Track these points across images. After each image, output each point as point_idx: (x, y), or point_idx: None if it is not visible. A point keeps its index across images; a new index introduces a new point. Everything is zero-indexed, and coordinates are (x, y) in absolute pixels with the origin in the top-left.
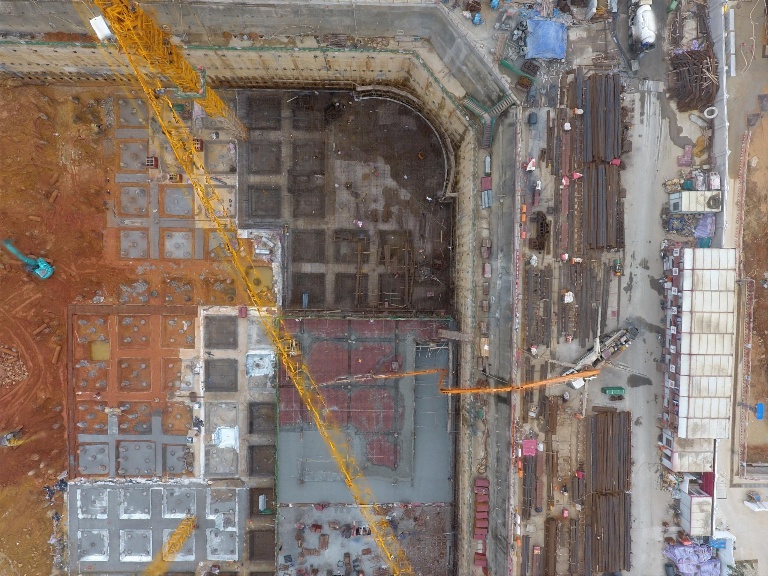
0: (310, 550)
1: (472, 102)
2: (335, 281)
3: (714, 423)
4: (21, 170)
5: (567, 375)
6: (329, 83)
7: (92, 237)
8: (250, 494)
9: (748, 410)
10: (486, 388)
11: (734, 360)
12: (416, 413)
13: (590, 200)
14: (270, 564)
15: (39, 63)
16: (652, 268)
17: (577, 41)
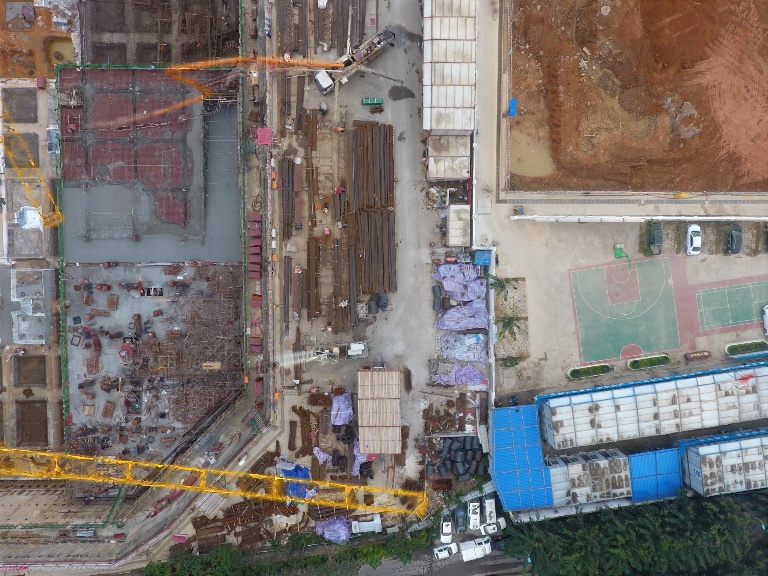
0: (98, 310)
1: None
2: (136, 51)
3: (459, 113)
4: None
5: None
6: None
7: None
8: (56, 275)
9: (528, 140)
10: (259, 121)
11: (497, 68)
12: (207, 171)
13: None
14: None
15: None
16: None
17: None
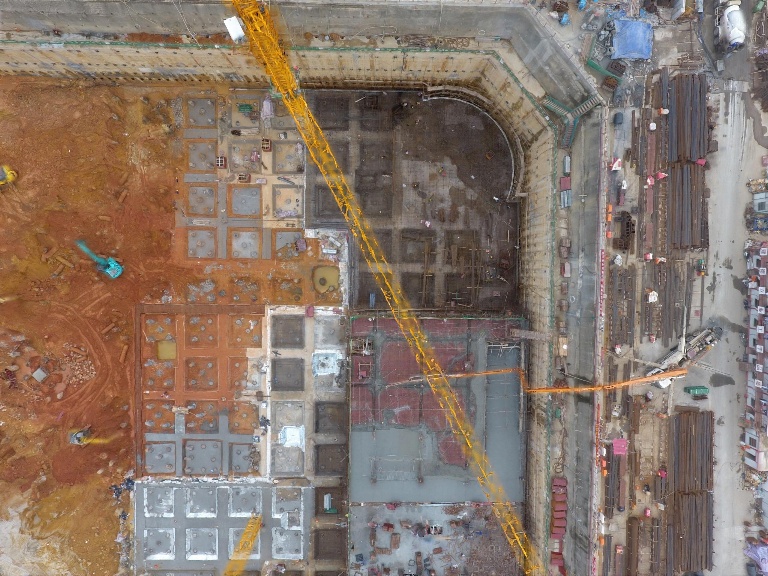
0: (382, 549)
1: (552, 102)
2: (402, 281)
3: None
4: (92, 170)
5: (656, 374)
6: (399, 83)
7: (160, 237)
8: (316, 493)
9: None
10: (563, 387)
11: None
12: (487, 412)
13: (675, 200)
14: (335, 563)
15: (117, 64)
16: (735, 268)
17: (663, 41)
